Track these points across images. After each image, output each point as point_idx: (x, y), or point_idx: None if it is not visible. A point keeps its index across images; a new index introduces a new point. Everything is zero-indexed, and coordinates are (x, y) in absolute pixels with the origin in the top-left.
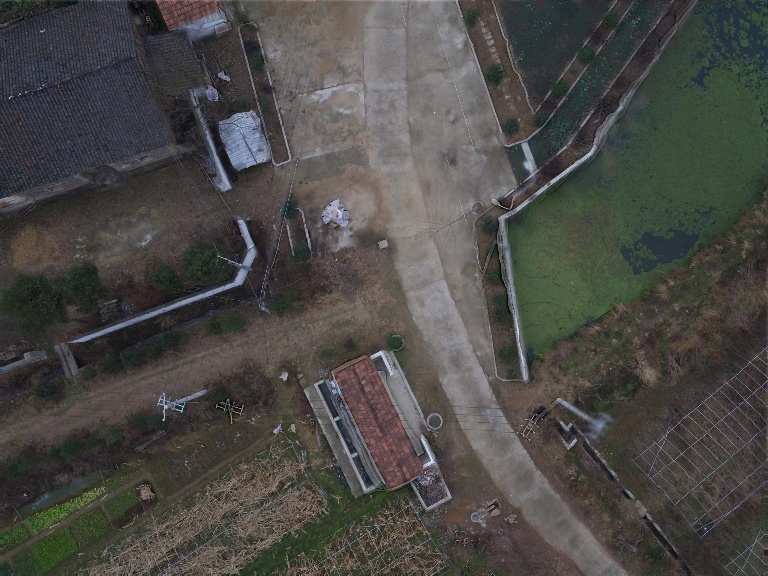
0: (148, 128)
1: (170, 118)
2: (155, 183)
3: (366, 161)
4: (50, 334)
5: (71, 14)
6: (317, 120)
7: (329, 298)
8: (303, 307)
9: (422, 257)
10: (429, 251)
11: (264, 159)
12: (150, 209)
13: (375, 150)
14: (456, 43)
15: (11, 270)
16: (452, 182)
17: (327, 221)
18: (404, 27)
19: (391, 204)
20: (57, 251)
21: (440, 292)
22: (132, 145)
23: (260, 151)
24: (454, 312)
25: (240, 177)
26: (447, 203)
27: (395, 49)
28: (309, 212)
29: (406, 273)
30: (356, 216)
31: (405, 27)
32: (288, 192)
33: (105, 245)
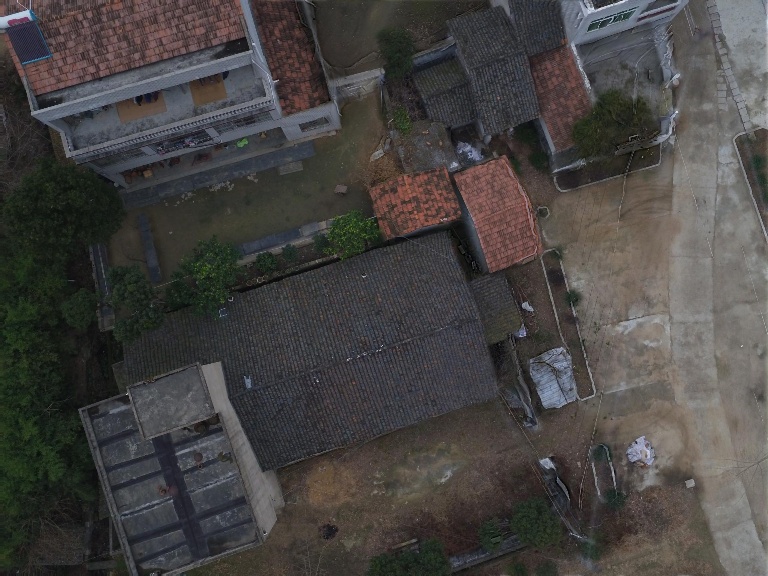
0: (479, 383)
1: (497, 369)
2: (455, 417)
3: (672, 396)
4: (347, 574)
5: (391, 256)
6: (622, 353)
7: (635, 539)
8: (610, 549)
9: (729, 497)
10: (736, 491)
11: (574, 398)
12: (450, 444)
13: (681, 385)
14: (763, 274)
15: (306, 507)
16: (760, 419)
17: (634, 460)
18: (710, 256)
19: (698, 441)
20: (354, 487)
21: (748, 533)
22: (460, 399)
23: (571, 390)
24: (761, 554)
25: (543, 412)
26: (755, 441)
27: (701, 279)
28: (614, 449)
29: (713, 513)
30: (662, 453)
31: (711, 256)
32: (592, 428)
33: (404, 481)
